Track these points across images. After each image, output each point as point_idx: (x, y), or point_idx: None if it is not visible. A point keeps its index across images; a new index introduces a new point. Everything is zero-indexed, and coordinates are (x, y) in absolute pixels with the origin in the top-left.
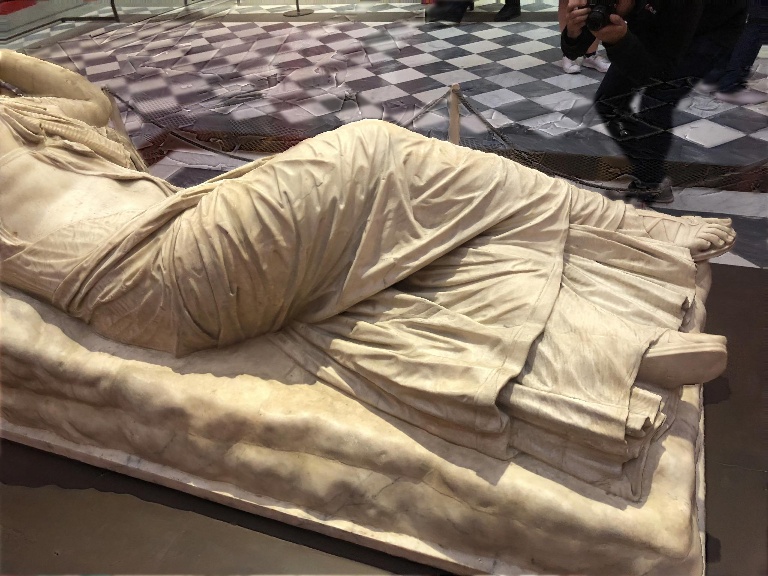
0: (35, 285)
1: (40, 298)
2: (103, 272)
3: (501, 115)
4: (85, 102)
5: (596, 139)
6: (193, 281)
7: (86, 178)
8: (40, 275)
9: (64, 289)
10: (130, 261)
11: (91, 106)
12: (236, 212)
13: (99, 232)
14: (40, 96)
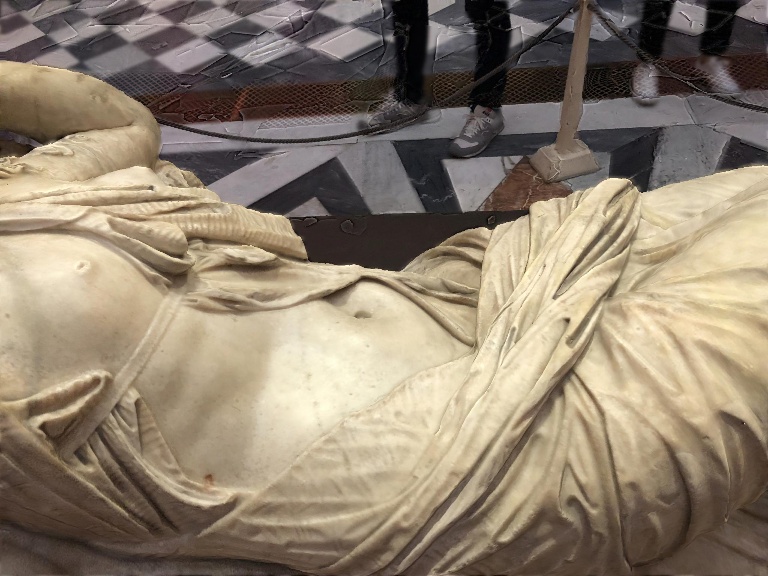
0: (266, 558)
1: (262, 565)
2: (446, 528)
3: (522, 19)
4: (128, 129)
5: (661, 37)
6: (654, 515)
7: (285, 315)
8: (287, 548)
9: (349, 565)
10: (498, 496)
11: (139, 134)
12: (757, 380)
13: (398, 442)
14: (50, 135)
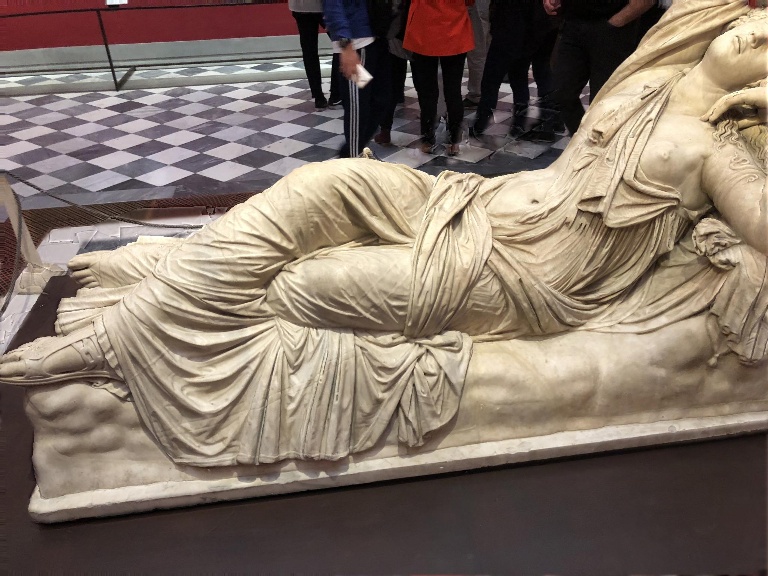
0: None
1: None
2: None
3: None
4: (759, 210)
5: None
6: None
7: None
8: None
9: None
10: None
11: (754, 216)
12: None
13: None
14: None
